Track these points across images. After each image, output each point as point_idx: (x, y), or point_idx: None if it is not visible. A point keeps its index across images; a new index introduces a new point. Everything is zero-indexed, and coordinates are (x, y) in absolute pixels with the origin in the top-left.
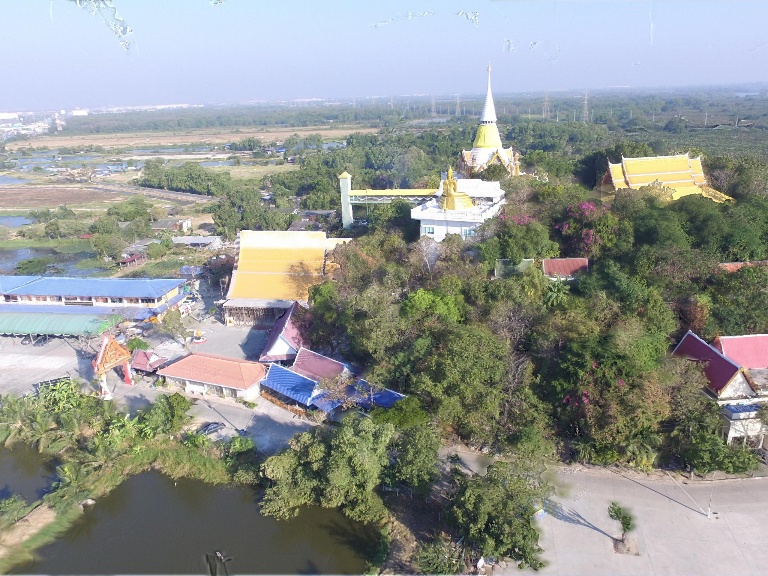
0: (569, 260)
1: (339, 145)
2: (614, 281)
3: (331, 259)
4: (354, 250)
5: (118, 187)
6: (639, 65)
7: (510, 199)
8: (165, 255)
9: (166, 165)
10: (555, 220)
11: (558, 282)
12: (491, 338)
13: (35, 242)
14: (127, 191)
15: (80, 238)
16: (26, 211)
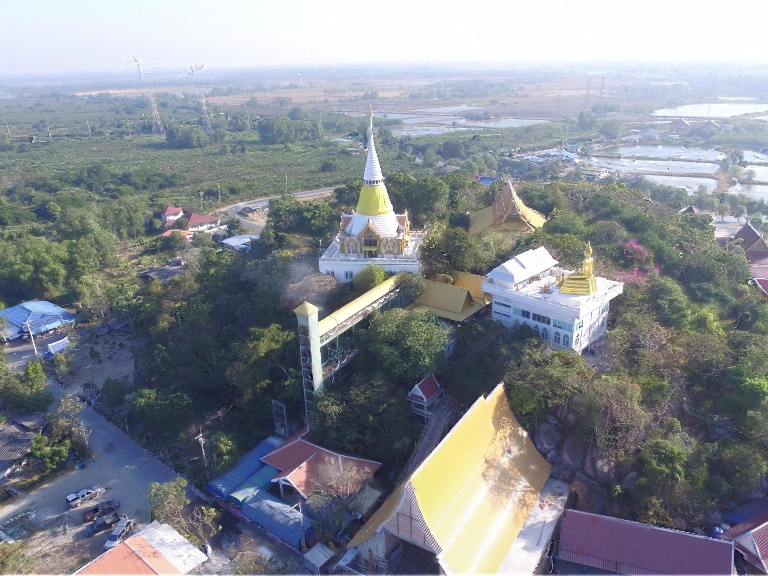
0: None
1: None
2: (725, 298)
3: (498, 428)
4: None
5: None
6: (362, 97)
7: None
8: None
9: None
10: None
11: None
12: None
13: None
14: None
15: None
16: None
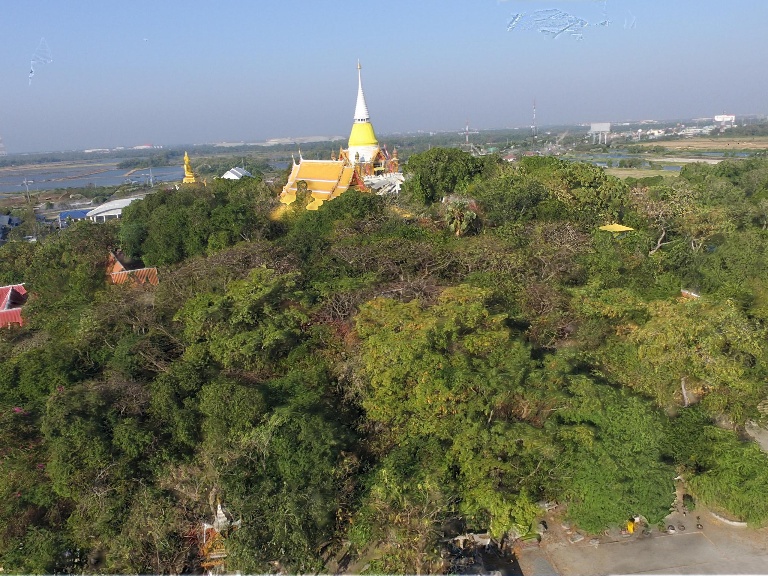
0: None
1: None
2: None
3: None
4: None
5: None
6: None
7: None
8: None
9: None
10: None
11: None
12: (8, 246)
13: None
14: None
15: None
16: None
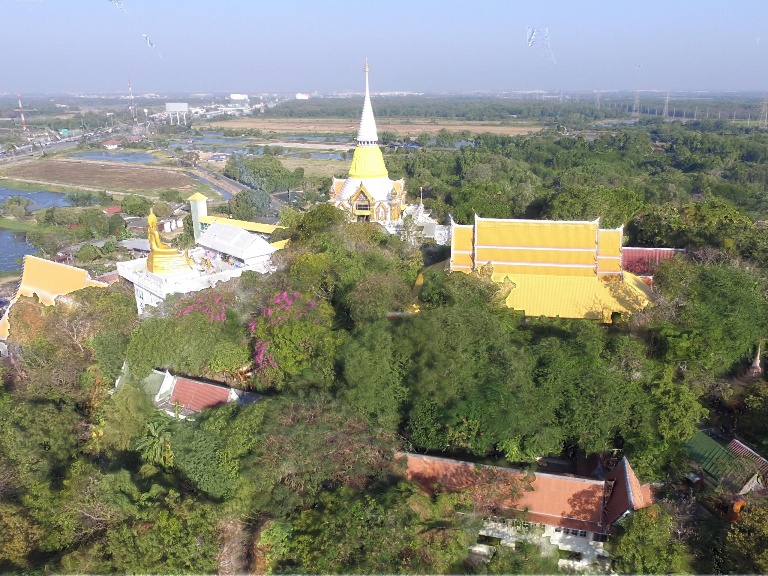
0: (207, 387)
1: (472, 144)
2: None
3: None
4: (20, 309)
5: (205, 174)
6: (639, 67)
7: (272, 262)
8: (99, 258)
9: (250, 156)
10: (258, 311)
11: (165, 422)
12: None
13: (36, 227)
14: (207, 179)
15: (68, 228)
16: (67, 194)
